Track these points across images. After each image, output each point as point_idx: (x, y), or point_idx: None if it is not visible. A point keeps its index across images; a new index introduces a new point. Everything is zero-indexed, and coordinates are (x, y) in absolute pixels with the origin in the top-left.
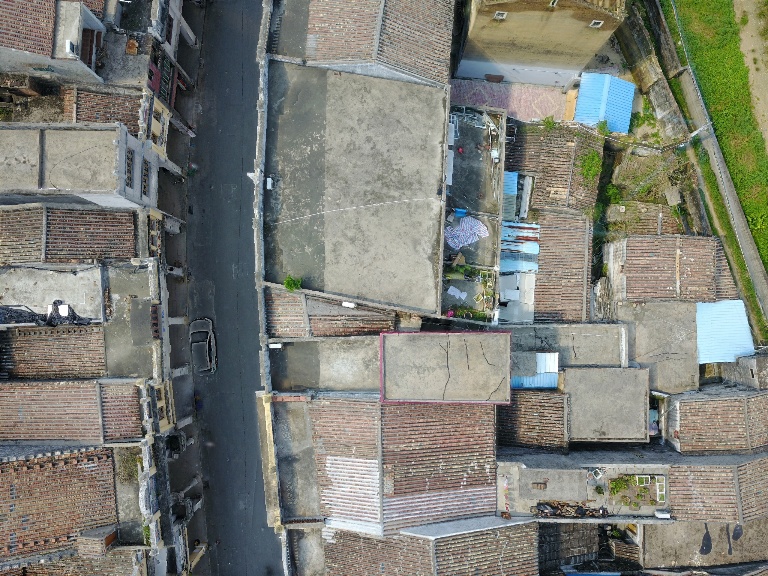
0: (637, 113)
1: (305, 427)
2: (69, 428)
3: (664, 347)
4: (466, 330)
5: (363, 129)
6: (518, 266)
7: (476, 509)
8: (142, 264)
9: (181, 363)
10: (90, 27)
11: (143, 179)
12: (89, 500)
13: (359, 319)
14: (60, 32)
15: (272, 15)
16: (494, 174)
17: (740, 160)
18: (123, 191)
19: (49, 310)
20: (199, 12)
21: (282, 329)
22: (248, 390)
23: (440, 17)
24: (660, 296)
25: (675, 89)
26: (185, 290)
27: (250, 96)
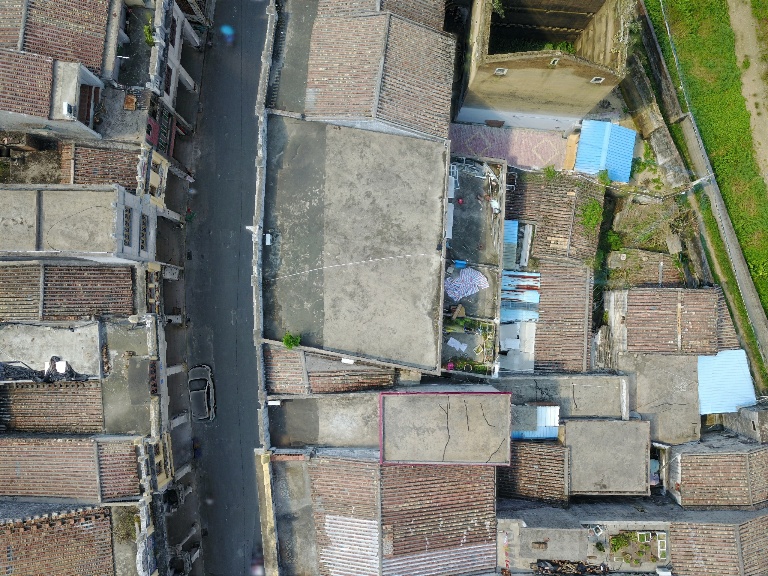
0: (638, 158)
1: (304, 485)
2: (66, 486)
3: (665, 397)
4: (466, 383)
5: (362, 184)
6: (518, 315)
7: (476, 566)
8: (140, 321)
9: (179, 410)
10: (88, 83)
11: (141, 234)
12: (86, 560)
13: (358, 374)
14: (57, 93)
15: (271, 68)
16: (494, 225)
17: (741, 206)
18: (121, 252)
19: (46, 367)
20: (198, 56)
21: (281, 385)
22: (247, 437)
23: (440, 71)
24: (661, 350)
25: (676, 134)
26: (184, 336)
27: (249, 141)
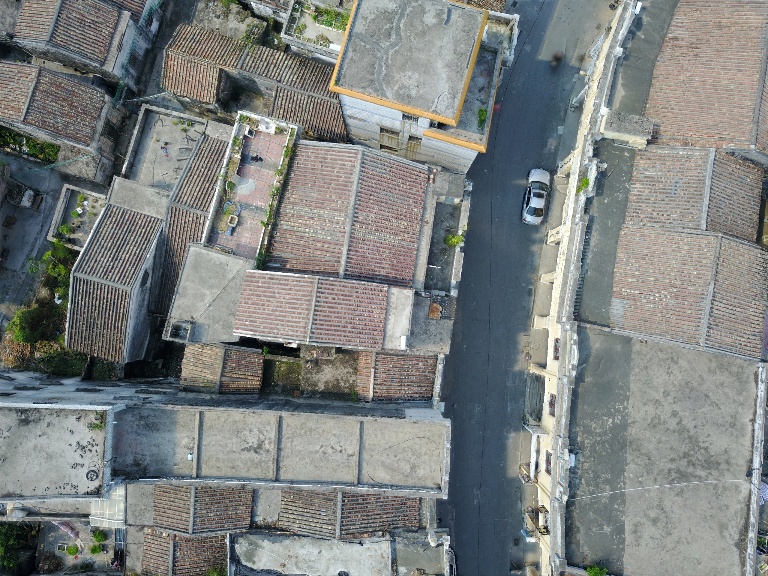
0: None
1: None
2: None
3: None
4: None
5: (669, 402)
6: None
7: None
8: (438, 542)
9: None
10: None
11: None
12: None
13: None
14: (390, 321)
15: None
16: None
17: None
18: None
19: None
20: None
21: None
22: None
23: (757, 288)
24: None
25: None
26: None
27: (497, 311)
